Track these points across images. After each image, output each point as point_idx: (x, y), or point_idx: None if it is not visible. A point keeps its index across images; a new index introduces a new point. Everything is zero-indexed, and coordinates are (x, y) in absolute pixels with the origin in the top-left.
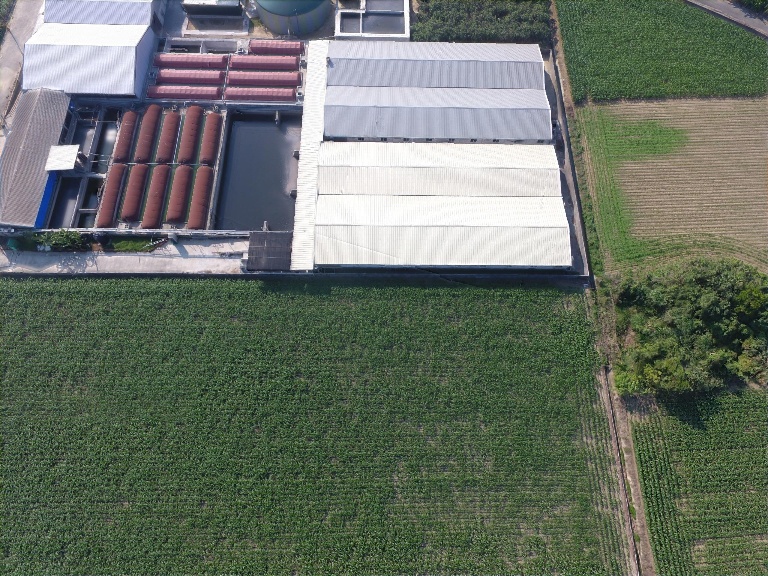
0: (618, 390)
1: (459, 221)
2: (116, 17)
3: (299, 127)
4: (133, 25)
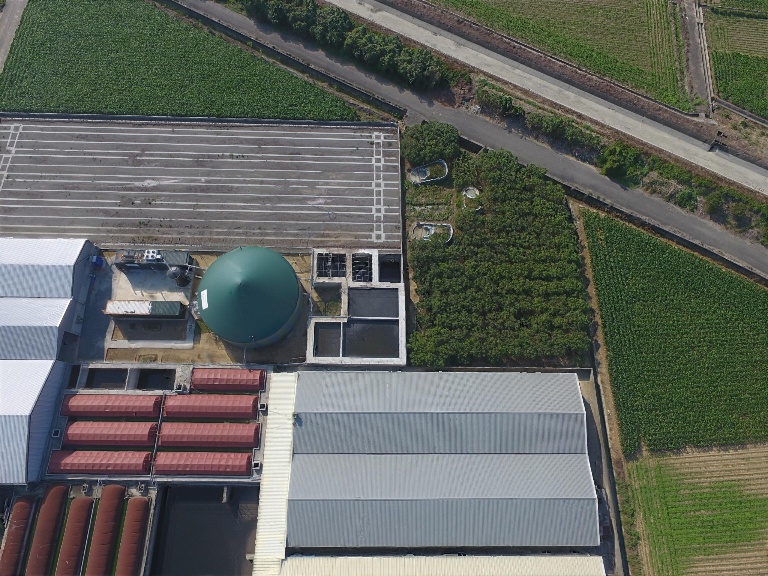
0: None
1: None
2: (10, 349)
3: (256, 503)
4: (33, 361)
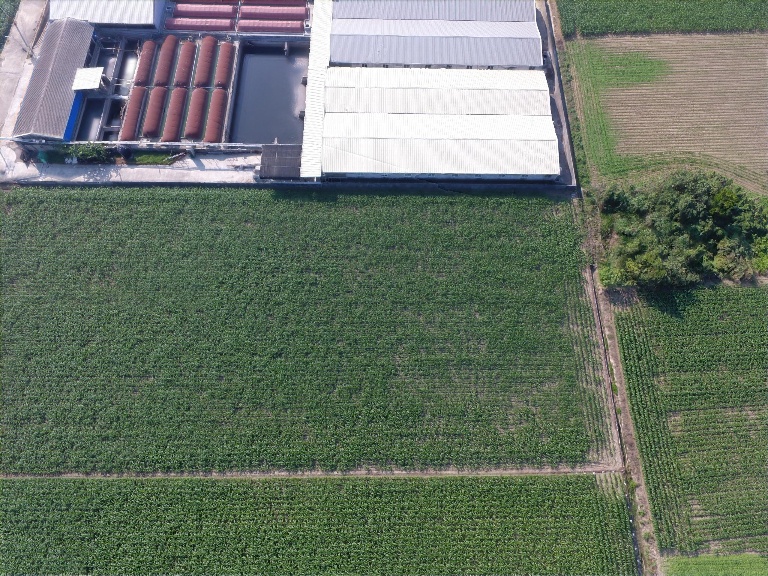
0: (602, 285)
1: (456, 135)
2: None
3: (306, 58)
4: None
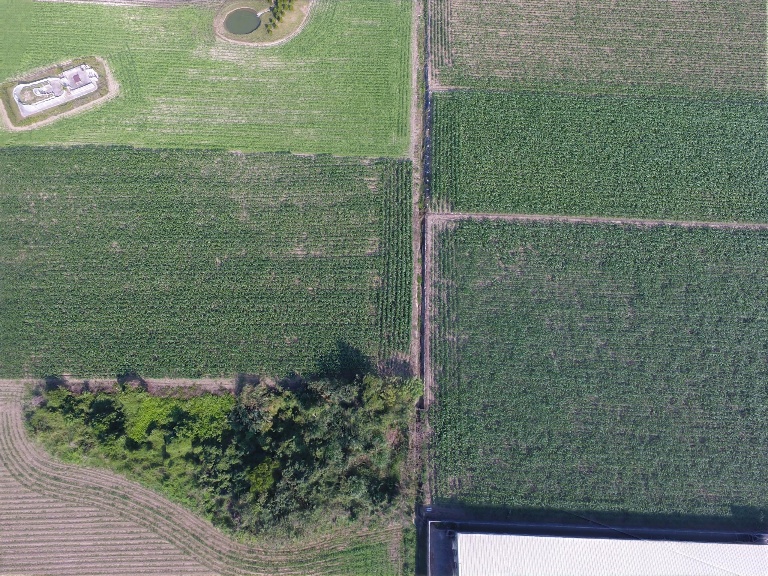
0: None
1: None
2: None
3: None
4: None
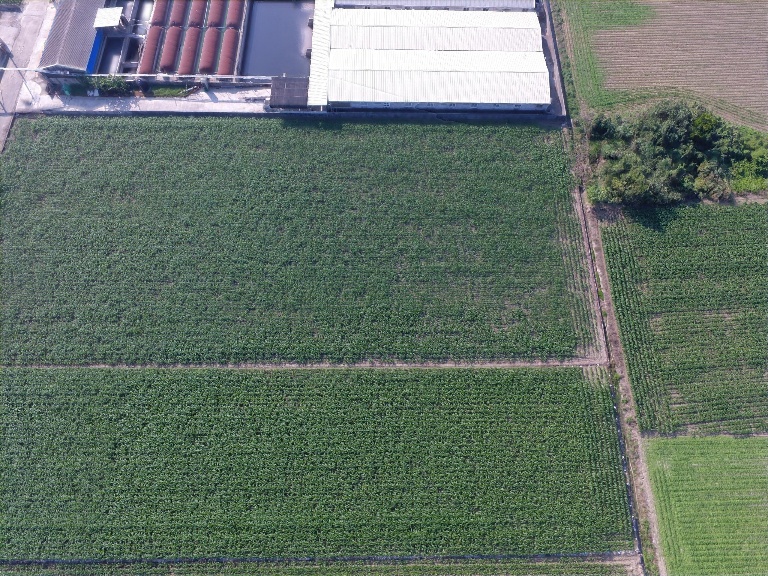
0: (590, 204)
1: (453, 67)
2: None
3: (312, 3)
4: None
